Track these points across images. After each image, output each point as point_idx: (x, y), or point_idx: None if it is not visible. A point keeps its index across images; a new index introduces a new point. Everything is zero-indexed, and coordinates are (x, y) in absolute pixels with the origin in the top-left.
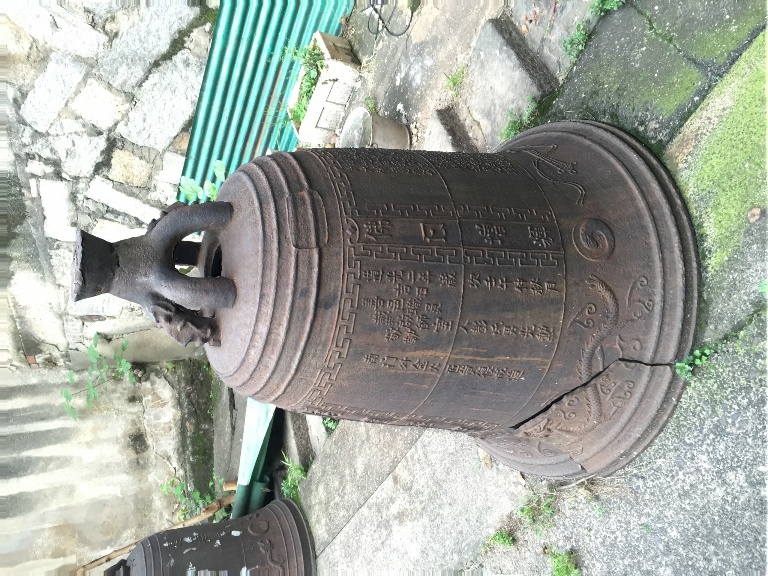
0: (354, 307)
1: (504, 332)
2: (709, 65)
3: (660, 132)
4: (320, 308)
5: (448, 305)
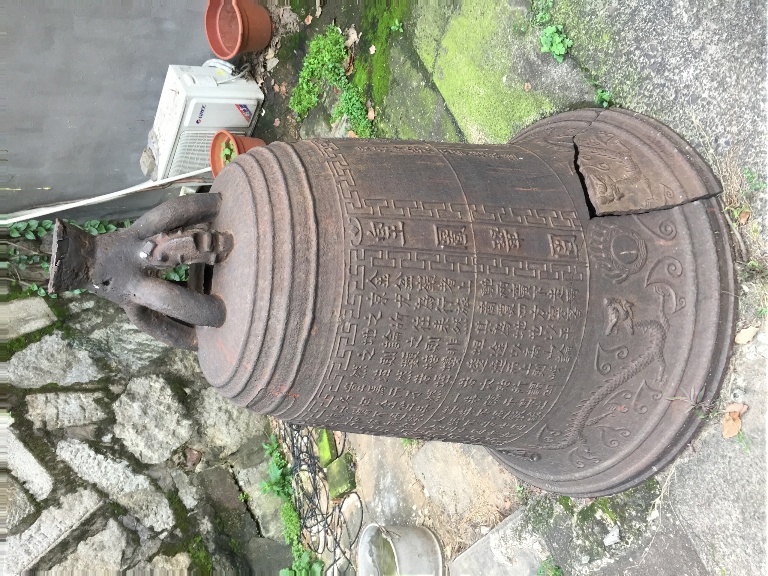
0: None
1: None
2: None
3: None
4: None
5: None
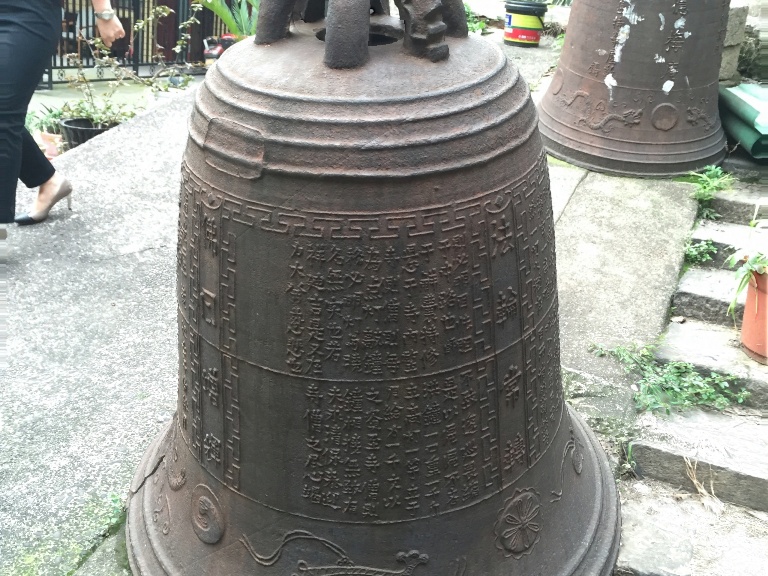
0: None
1: None
2: None
3: None
4: None
5: None
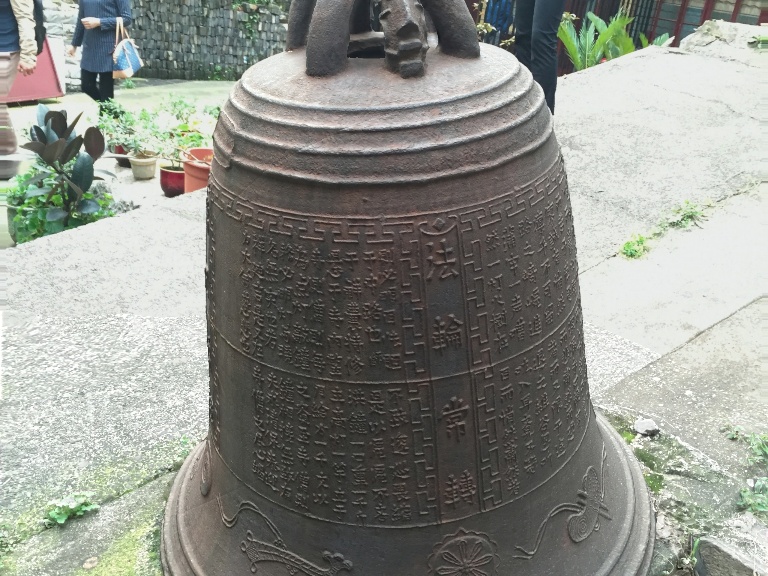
0: None
1: None
2: None
3: None
4: None
5: None
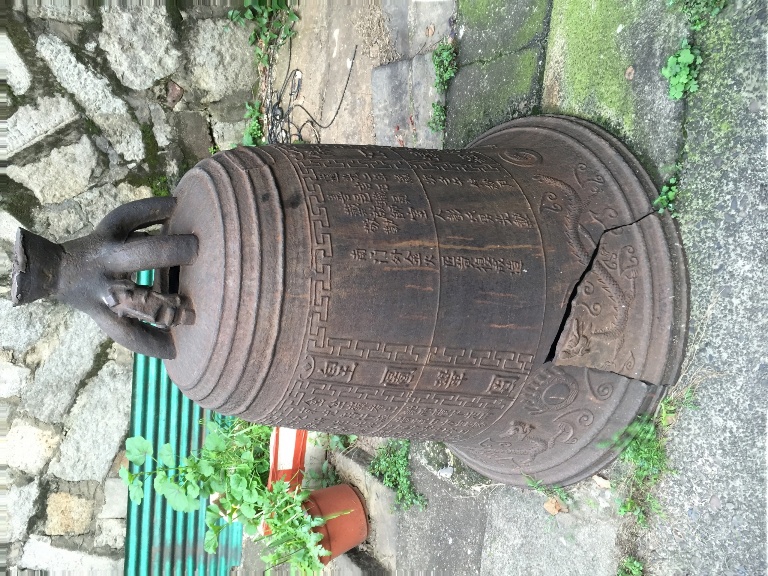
0: (321, 202)
1: (481, 220)
2: (535, 39)
3: (530, 103)
4: (287, 209)
5: (414, 197)
